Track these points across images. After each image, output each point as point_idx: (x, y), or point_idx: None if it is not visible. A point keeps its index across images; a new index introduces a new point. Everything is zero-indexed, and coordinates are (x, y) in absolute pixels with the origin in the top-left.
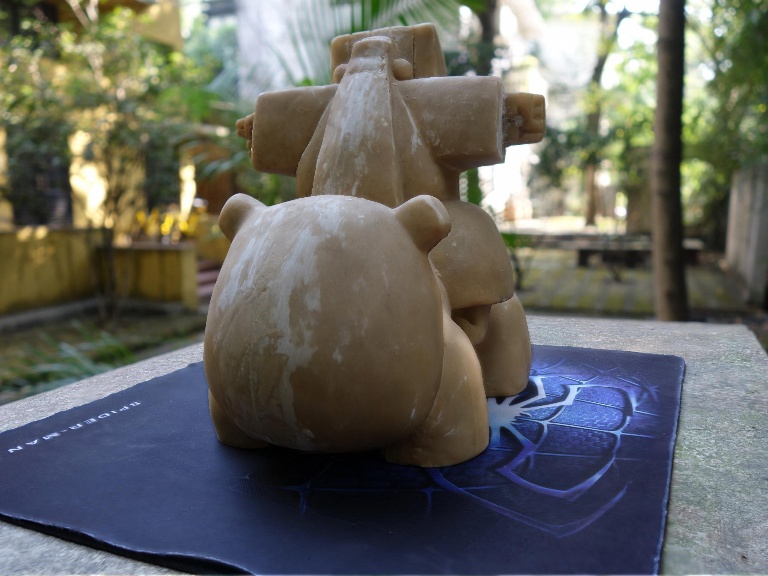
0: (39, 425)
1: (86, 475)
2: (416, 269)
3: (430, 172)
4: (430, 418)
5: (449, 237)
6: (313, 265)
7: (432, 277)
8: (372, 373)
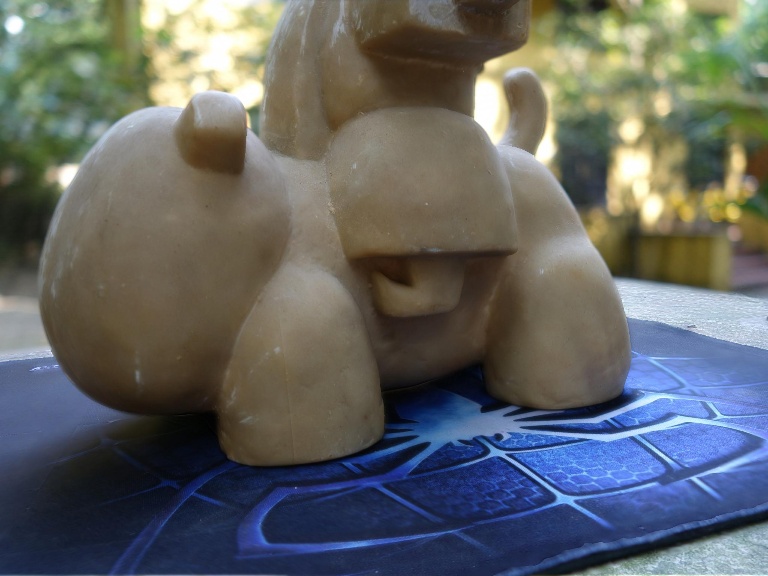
0: None
1: (54, 390)
2: (164, 190)
3: (352, 68)
4: (224, 394)
5: (353, 156)
6: (70, 186)
7: (219, 204)
8: (77, 315)
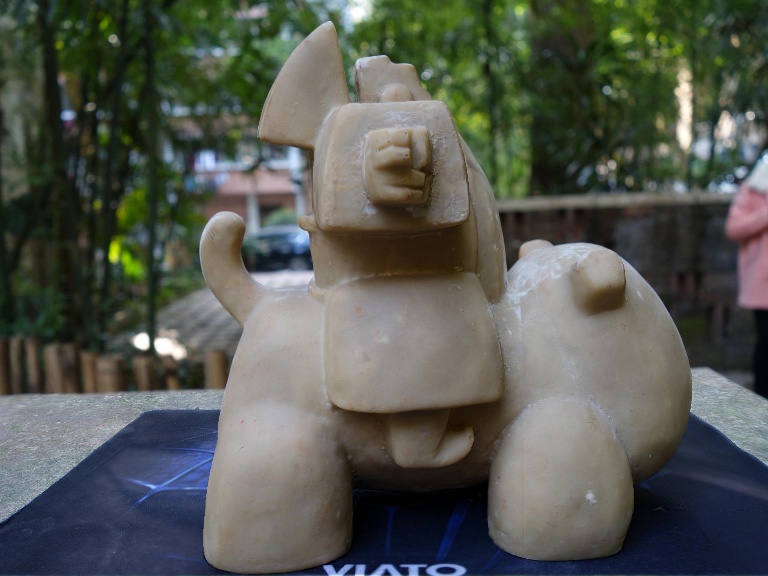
0: None
1: None
2: None
3: None
4: None
5: None
6: None
7: None
8: None
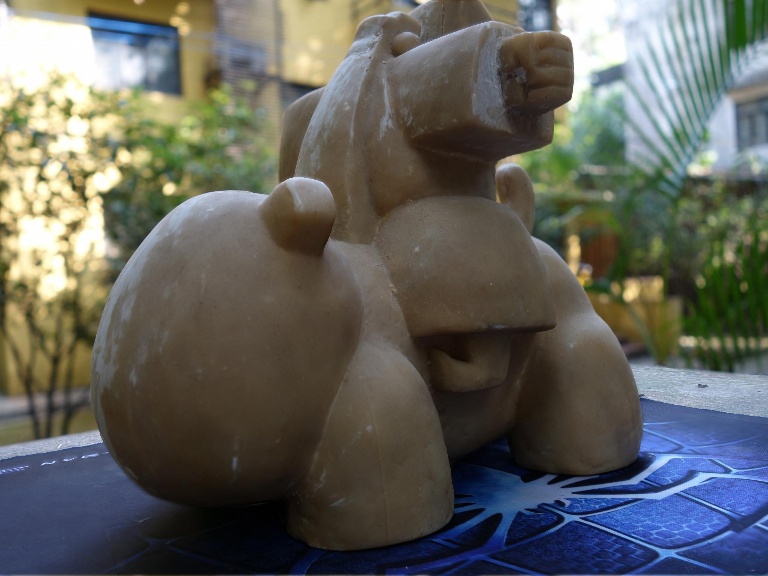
0: (102, 446)
1: (42, 493)
2: (260, 272)
3: (402, 160)
4: (311, 478)
5: (413, 241)
6: (140, 269)
7: (309, 285)
8: (168, 402)
